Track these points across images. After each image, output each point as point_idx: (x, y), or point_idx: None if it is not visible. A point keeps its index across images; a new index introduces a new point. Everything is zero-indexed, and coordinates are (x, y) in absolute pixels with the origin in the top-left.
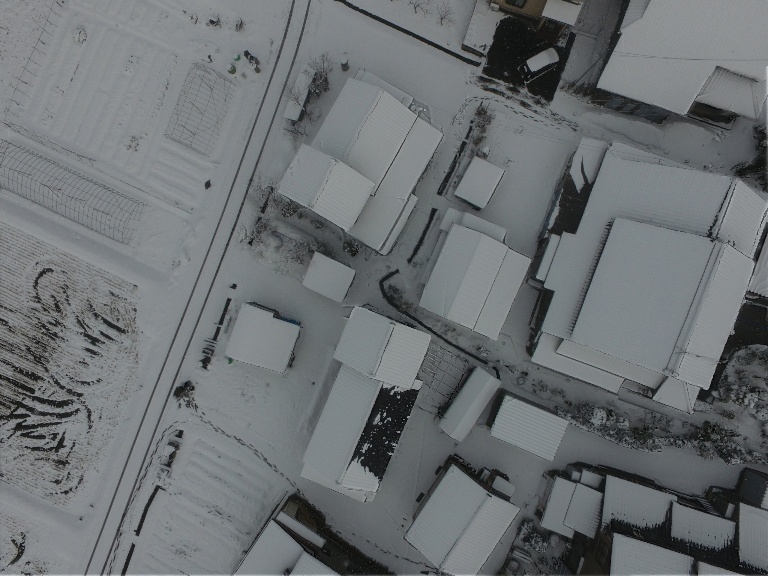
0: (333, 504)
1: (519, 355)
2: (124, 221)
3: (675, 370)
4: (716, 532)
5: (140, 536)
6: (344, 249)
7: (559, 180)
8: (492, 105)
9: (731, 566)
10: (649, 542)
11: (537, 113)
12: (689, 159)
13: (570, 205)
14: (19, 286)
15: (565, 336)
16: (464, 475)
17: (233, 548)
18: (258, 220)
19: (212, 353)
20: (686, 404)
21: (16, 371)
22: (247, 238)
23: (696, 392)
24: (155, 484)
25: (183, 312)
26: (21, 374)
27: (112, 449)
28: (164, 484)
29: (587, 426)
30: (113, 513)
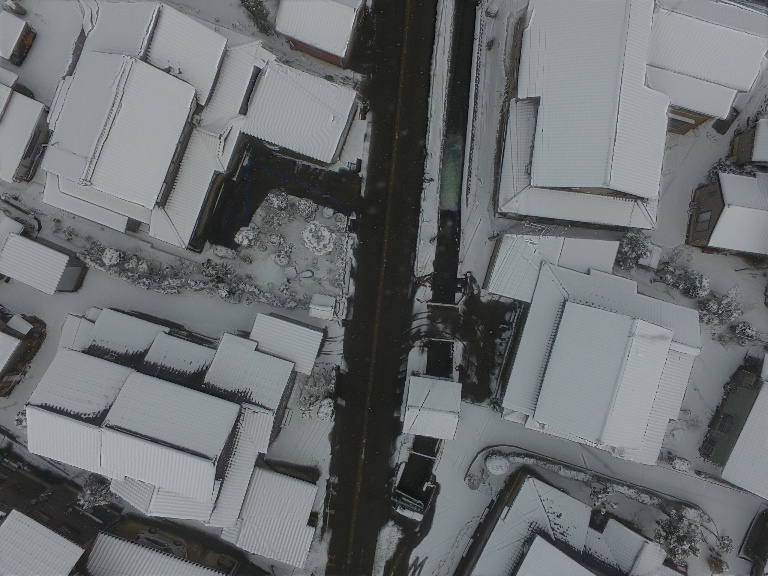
0: None
1: None
2: None
3: None
4: (193, 358)
5: None
6: None
7: None
8: None
9: (192, 385)
10: (98, 357)
11: None
12: (218, 17)
13: None
14: None
15: None
16: None
17: None
18: None
19: None
20: (177, 238)
21: None
22: None
23: (189, 228)
24: None
25: None
26: None
27: None
28: None
29: (105, 268)
30: None
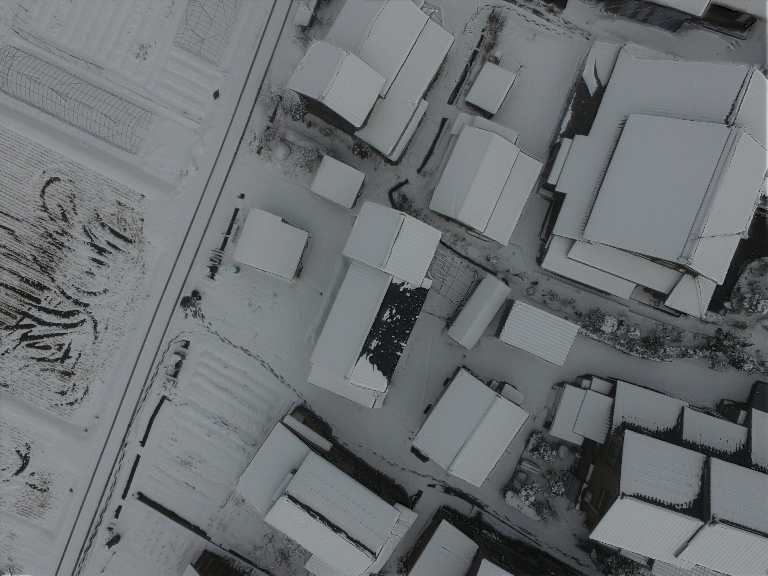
0: (340, 416)
1: (529, 266)
2: (132, 126)
3: (690, 256)
4: (728, 436)
5: (145, 447)
6: (354, 151)
7: (571, 87)
8: (504, 13)
9: None
10: None
11: (549, 21)
12: None
13: (583, 109)
14: (26, 195)
15: (577, 237)
16: (473, 378)
17: (239, 460)
18: (267, 129)
19: (219, 262)
20: (699, 308)
21: (22, 281)
22: (256, 140)
23: (709, 297)
24: (161, 395)
25: (190, 221)
26: (27, 284)
27: (118, 360)
28: (170, 394)
29: (597, 335)
30: (118, 423)
